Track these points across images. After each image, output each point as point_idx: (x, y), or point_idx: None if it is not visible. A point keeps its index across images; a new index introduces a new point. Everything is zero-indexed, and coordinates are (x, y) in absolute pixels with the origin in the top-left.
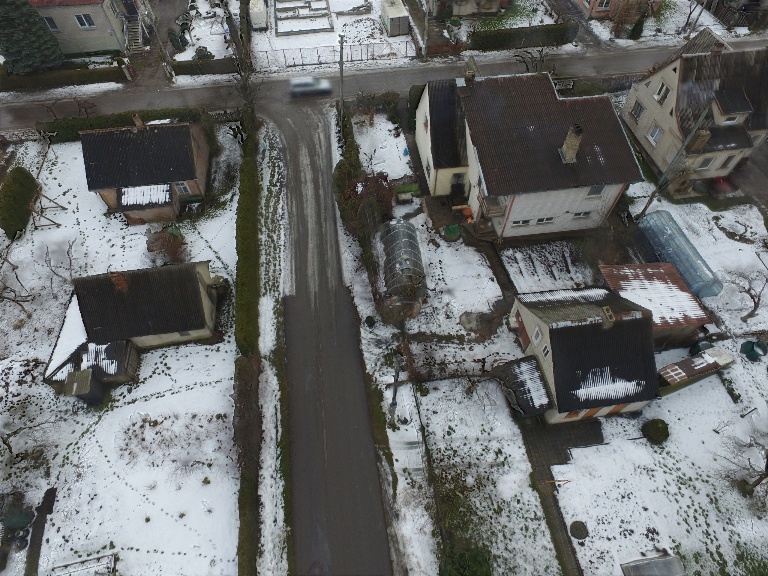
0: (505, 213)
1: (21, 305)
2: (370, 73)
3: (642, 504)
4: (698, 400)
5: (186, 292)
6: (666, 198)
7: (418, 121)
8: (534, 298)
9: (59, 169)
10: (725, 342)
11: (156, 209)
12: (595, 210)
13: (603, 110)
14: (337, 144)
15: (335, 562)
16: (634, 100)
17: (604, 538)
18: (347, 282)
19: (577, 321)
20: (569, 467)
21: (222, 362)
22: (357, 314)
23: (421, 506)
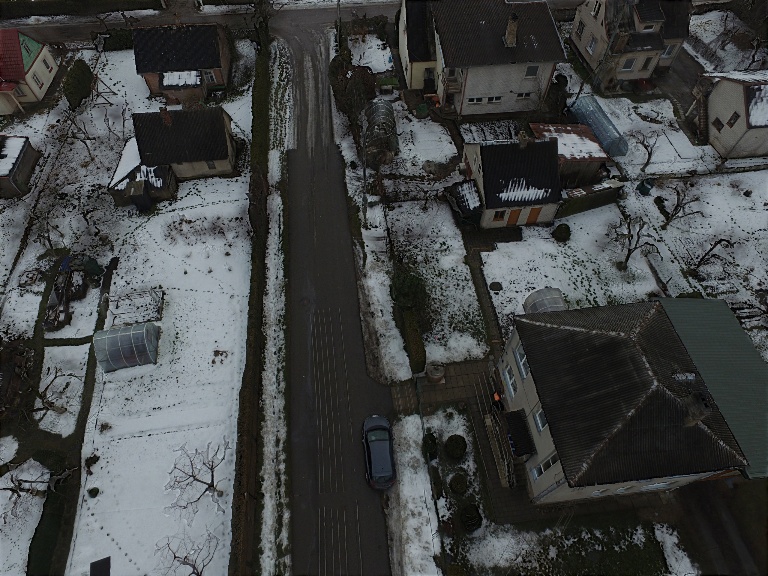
0: (461, 90)
1: (88, 147)
2: (365, 5)
3: (544, 273)
4: (598, 218)
5: (215, 129)
6: (598, 94)
7: (400, 32)
8: (477, 142)
9: (109, 68)
10: (625, 183)
11: (189, 90)
12: (534, 91)
13: (541, 11)
14: (335, 54)
15: (319, 297)
16: (578, 20)
17: (513, 291)
18: (337, 142)
19: (501, 141)
20: (494, 252)
21: (240, 188)
22: (344, 161)
23: (383, 271)
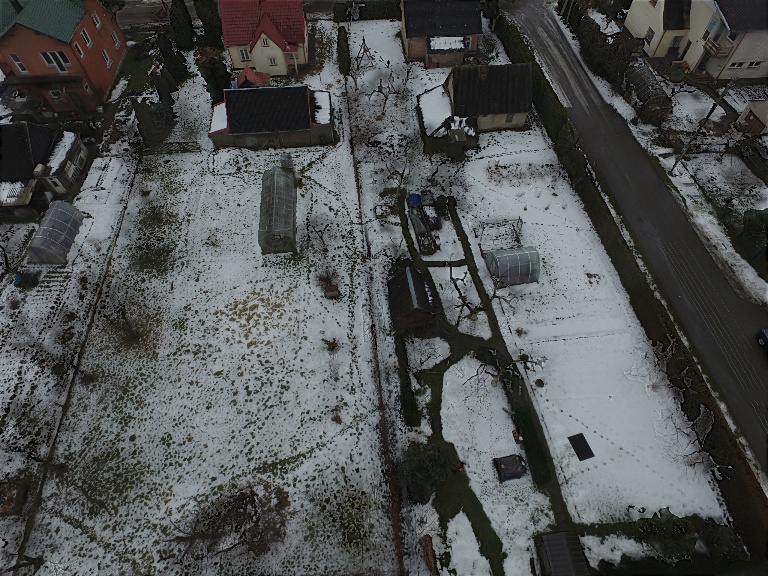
0: (729, 54)
1: None
2: None
3: None
4: None
5: (523, 84)
6: None
7: (637, 4)
8: None
9: (354, 36)
10: None
11: (453, 54)
12: None
13: None
14: (564, 25)
15: (660, 232)
16: None
17: None
18: (608, 101)
19: None
20: None
21: (535, 140)
22: (623, 118)
23: (706, 212)
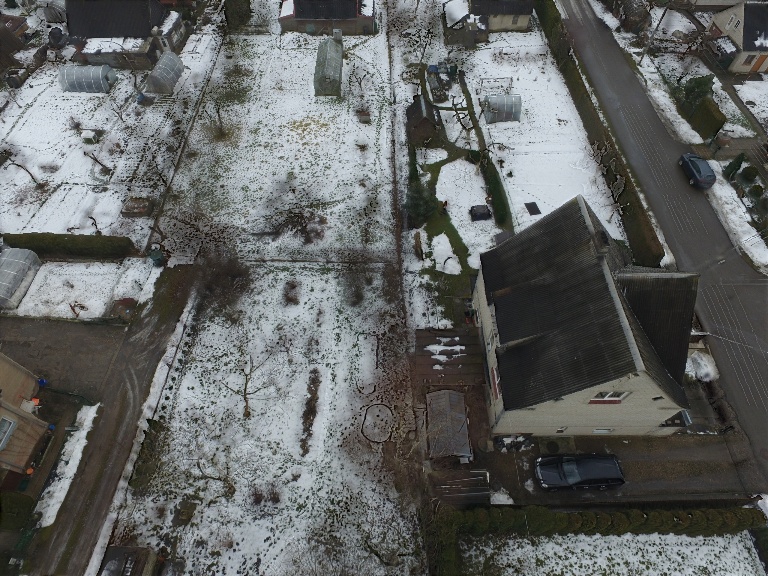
0: None
1: None
2: None
3: None
4: None
5: None
6: None
7: None
8: None
9: None
10: None
11: None
12: None
13: None
14: None
15: (621, 98)
16: None
17: (765, 107)
18: (599, 16)
19: None
20: (744, 85)
21: (535, 39)
22: (609, 28)
23: (661, 90)
